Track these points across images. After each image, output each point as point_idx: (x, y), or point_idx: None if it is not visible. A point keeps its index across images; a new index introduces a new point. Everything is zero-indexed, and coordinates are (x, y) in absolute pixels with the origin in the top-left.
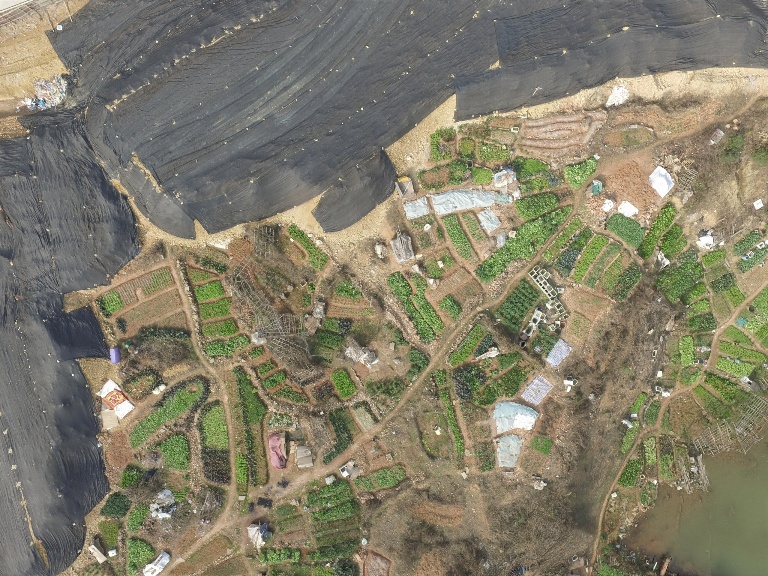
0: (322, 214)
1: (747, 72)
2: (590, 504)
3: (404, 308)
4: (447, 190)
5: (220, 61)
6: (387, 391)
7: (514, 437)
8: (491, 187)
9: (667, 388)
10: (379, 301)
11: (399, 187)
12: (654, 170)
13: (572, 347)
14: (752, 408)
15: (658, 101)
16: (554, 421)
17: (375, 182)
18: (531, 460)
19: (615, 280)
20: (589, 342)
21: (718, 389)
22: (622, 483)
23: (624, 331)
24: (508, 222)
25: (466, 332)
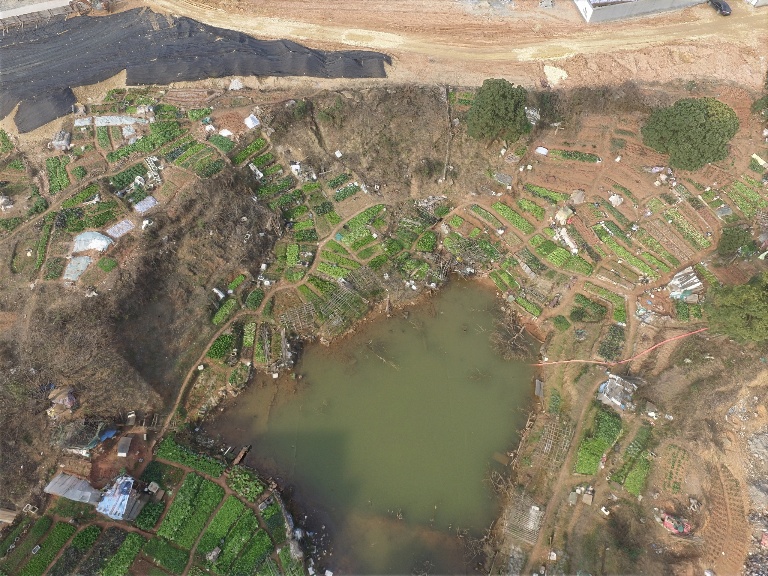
0: (19, 119)
1: (315, 80)
2: (168, 365)
3: (49, 176)
4: (108, 115)
5: (2, 53)
6: (6, 224)
7: (86, 257)
8: (136, 115)
9: (270, 280)
10: (34, 171)
11: (75, 109)
12: (249, 116)
13: (159, 202)
14: (338, 296)
15: (262, 90)
16: (125, 249)
17: (57, 101)
18: (92, 275)
19: (204, 167)
20: (174, 201)
21: (318, 288)
22: (210, 355)
23: (208, 202)
24: (140, 131)
25: (82, 187)
